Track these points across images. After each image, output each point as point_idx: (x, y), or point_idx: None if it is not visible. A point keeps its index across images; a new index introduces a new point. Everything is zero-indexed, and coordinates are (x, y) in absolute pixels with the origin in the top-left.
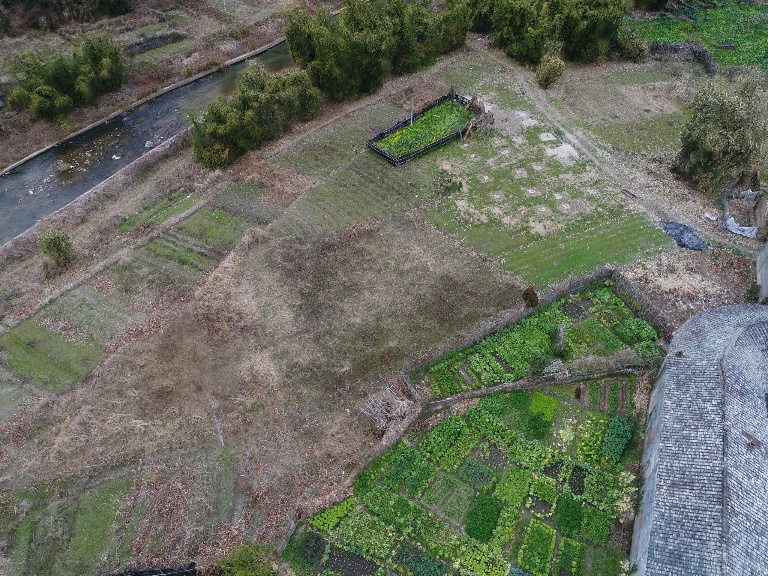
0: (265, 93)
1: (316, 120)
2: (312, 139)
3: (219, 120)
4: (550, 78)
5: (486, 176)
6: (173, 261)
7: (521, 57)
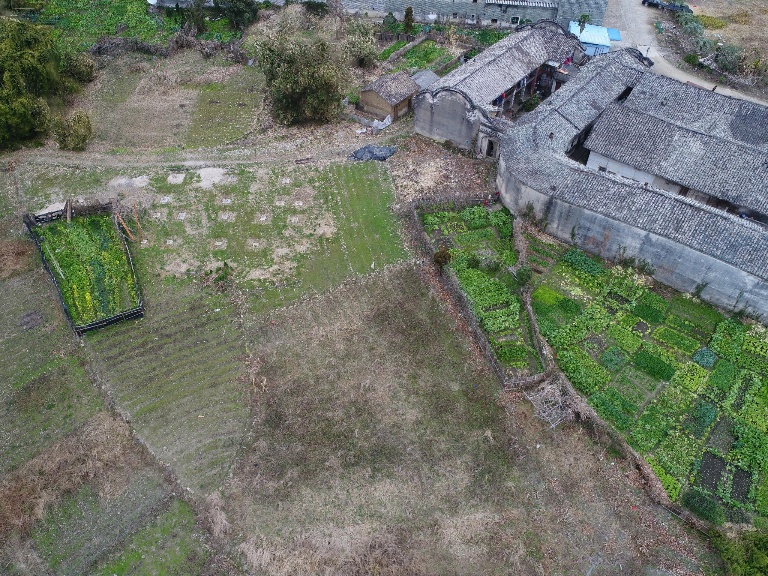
0: None
1: None
2: None
3: None
4: (87, 135)
5: (216, 242)
6: None
7: (5, 143)
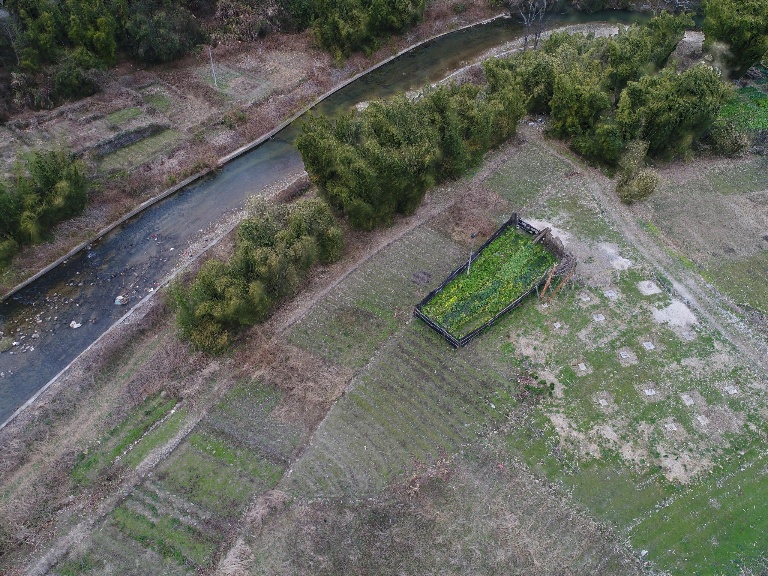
0: (276, 250)
1: (340, 262)
2: (338, 296)
3: (214, 293)
4: (639, 196)
5: (582, 364)
6: (151, 550)
7: (591, 156)
